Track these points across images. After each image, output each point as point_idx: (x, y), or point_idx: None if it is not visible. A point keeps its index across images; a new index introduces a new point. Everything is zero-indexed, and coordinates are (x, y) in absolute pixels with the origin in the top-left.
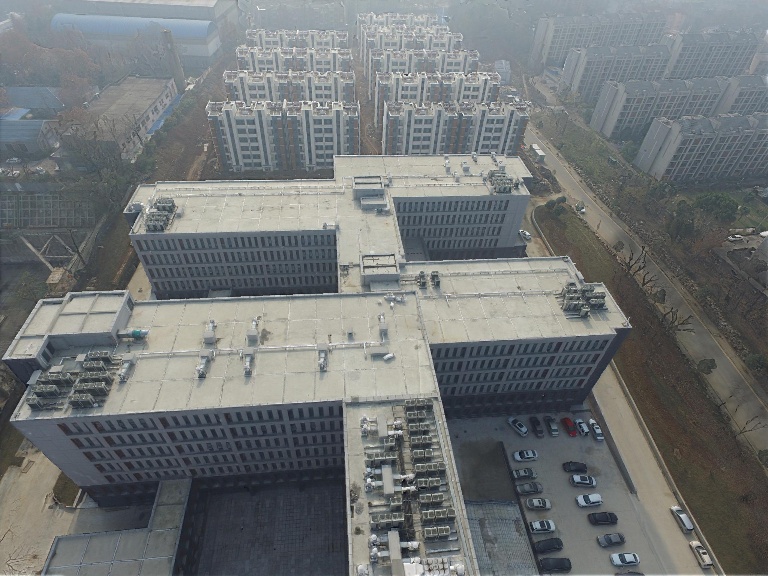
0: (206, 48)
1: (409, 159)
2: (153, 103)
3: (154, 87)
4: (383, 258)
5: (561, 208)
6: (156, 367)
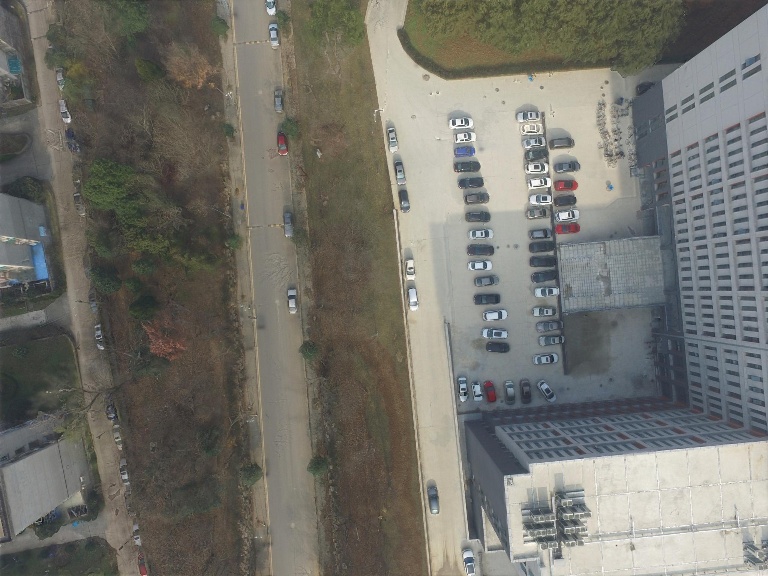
0: None
1: None
2: None
3: None
4: None
5: None
6: None
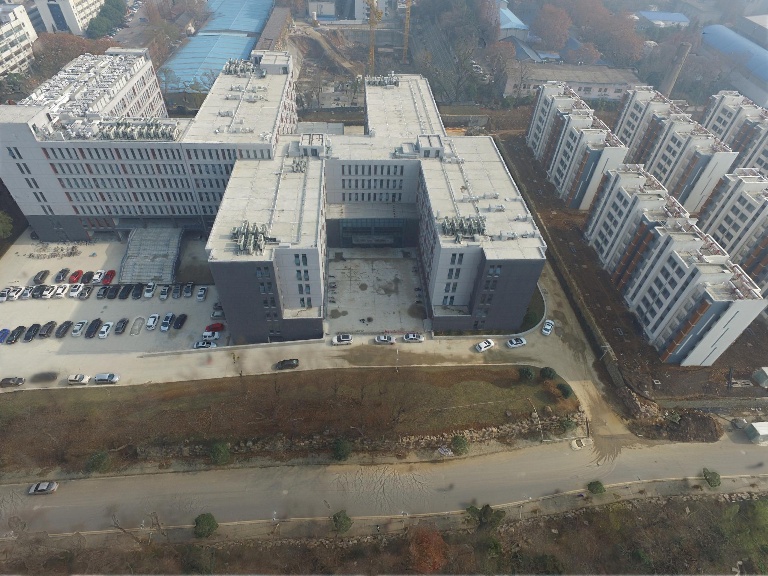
0: (767, 98)
1: (502, 176)
2: (587, 83)
3: (619, 80)
4: (320, 142)
5: (526, 370)
6: (242, 81)
